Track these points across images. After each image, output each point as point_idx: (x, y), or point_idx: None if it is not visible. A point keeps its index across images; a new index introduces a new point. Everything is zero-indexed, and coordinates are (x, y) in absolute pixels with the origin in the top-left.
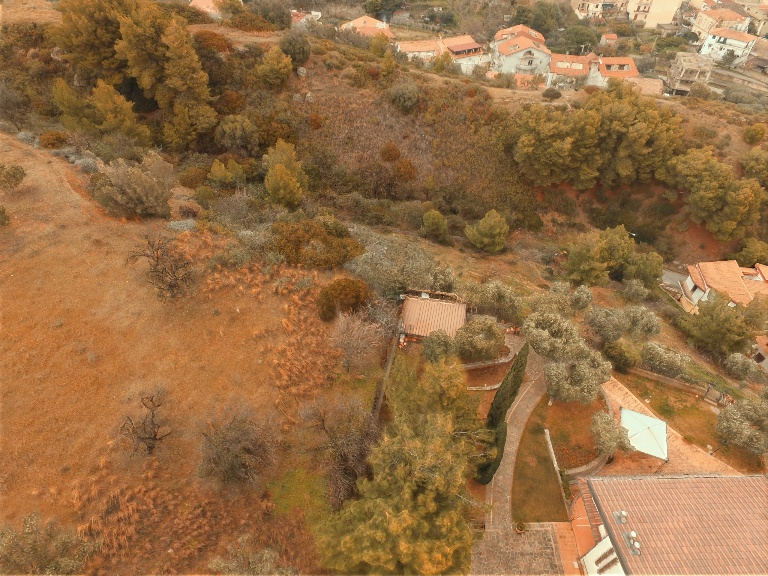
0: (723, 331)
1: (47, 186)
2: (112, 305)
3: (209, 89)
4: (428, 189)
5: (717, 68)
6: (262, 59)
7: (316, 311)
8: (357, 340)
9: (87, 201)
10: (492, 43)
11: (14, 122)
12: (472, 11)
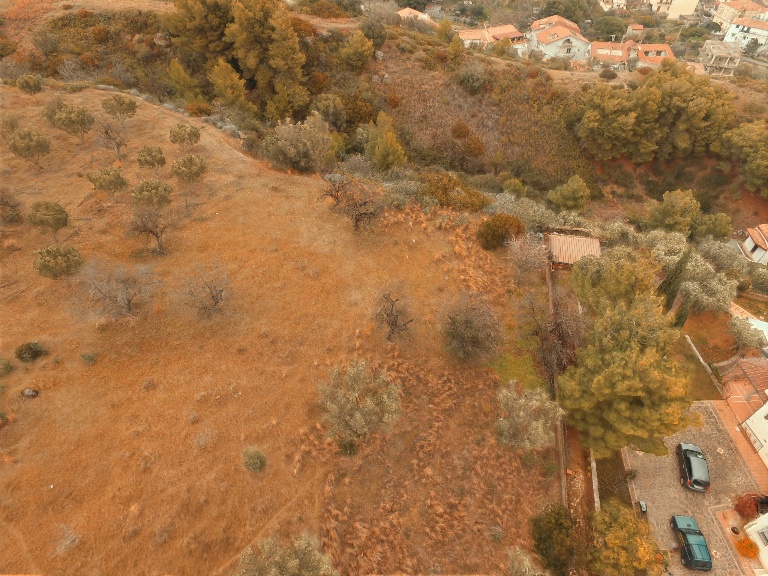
0: None
1: (211, 146)
2: (309, 236)
3: (301, 70)
4: (497, 164)
5: (745, 55)
6: (344, 43)
7: (476, 243)
8: (534, 257)
9: (250, 158)
10: (528, 33)
11: (158, 94)
12: (501, 4)
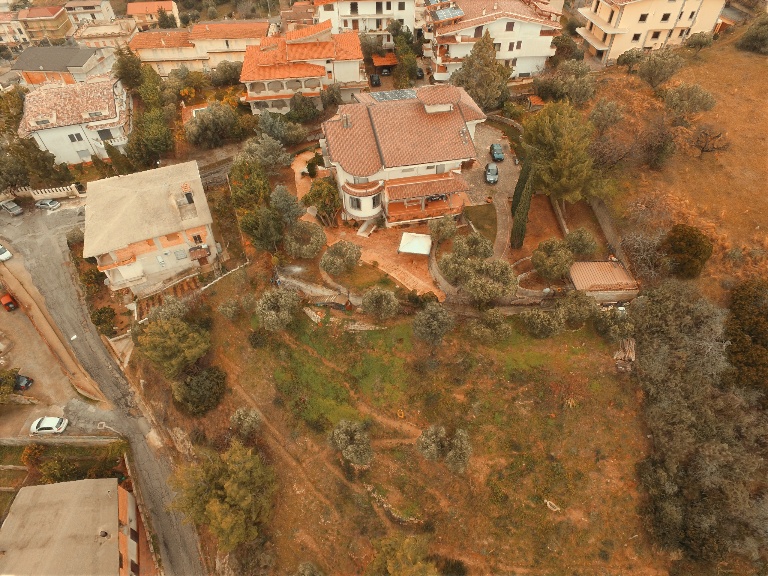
0: None
1: None
2: None
3: None
4: None
5: None
6: None
7: None
8: None
9: None
10: None
11: None
12: None
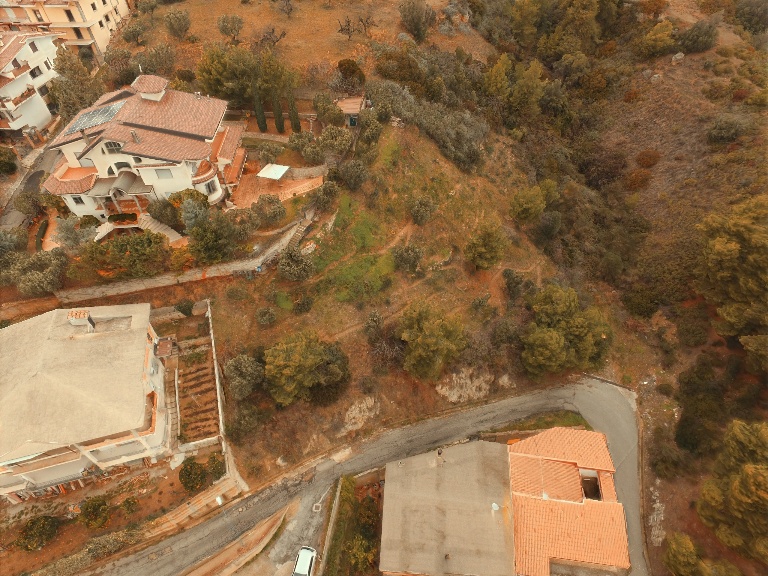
0: None
1: None
2: None
3: (597, 31)
4: (625, 204)
5: None
6: None
7: None
8: (311, 64)
9: None
10: None
11: None
12: None
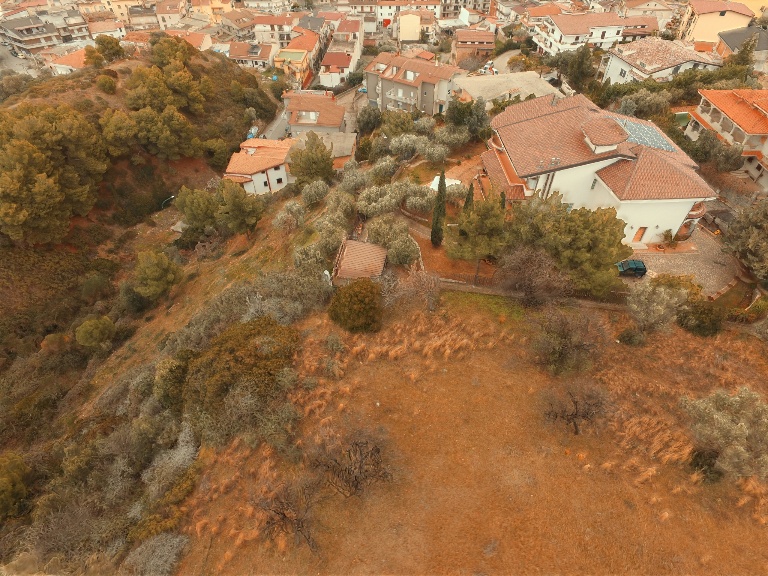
0: (327, 162)
1: None
2: None
3: None
4: None
5: None
6: None
7: (366, 338)
8: None
9: None
10: None
11: None
12: None
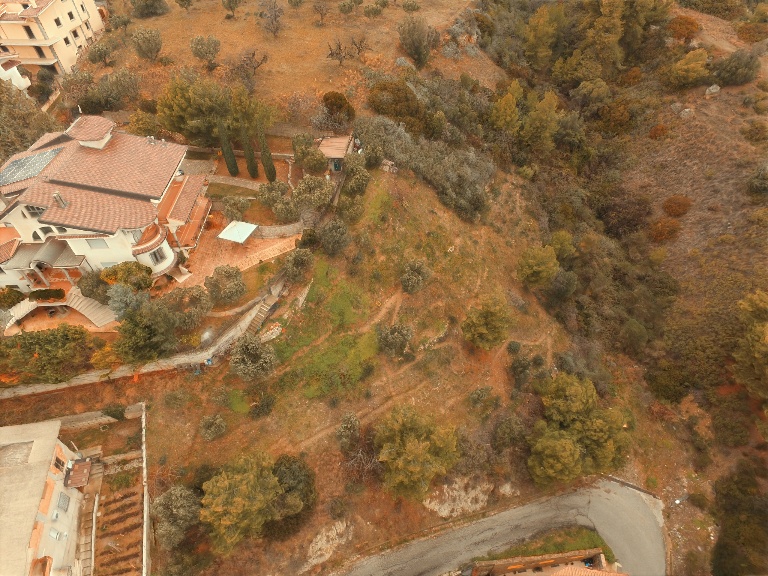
0: None
1: None
2: None
3: (620, 56)
4: (649, 258)
5: None
6: None
7: None
8: (292, 98)
9: None
10: None
11: (482, 3)
12: None
